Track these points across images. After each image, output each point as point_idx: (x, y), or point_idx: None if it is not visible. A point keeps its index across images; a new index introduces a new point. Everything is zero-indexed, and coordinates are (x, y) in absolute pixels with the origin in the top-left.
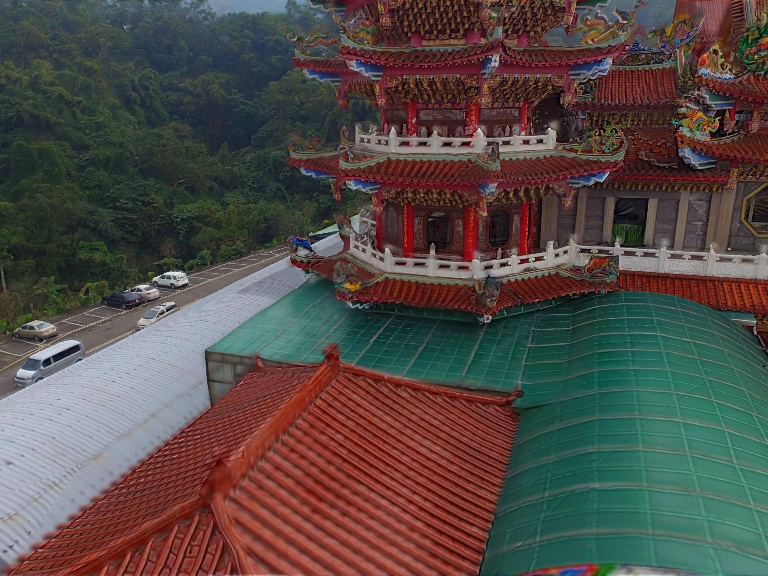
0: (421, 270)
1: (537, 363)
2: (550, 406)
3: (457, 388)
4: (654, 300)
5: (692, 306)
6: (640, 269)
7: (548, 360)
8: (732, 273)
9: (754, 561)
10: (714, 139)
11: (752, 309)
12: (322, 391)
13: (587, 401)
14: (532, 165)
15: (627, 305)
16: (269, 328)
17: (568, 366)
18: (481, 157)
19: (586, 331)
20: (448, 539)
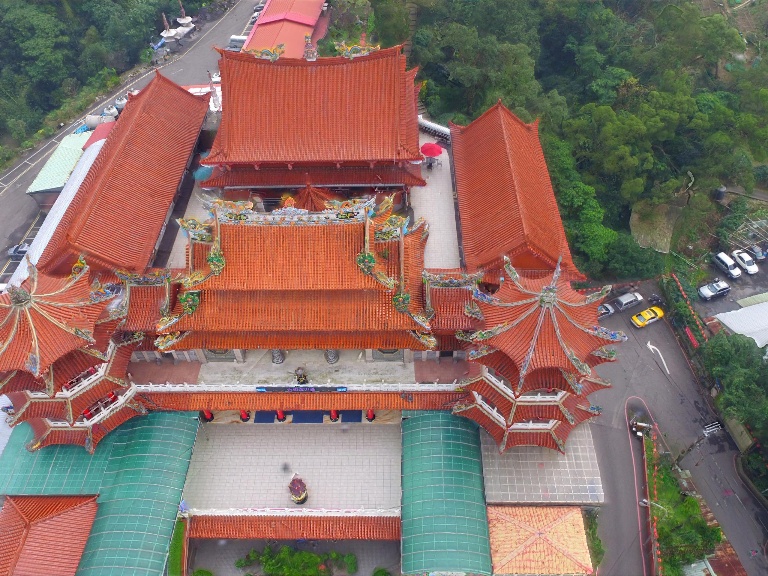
0: (65, 425)
1: (108, 473)
2: (104, 503)
3: (80, 495)
4: (158, 422)
5: (172, 420)
6: (163, 390)
7: (112, 471)
8: (196, 389)
9: (120, 568)
10: (180, 337)
11: (198, 410)
12: (26, 538)
13: (111, 505)
14: (93, 393)
15: (147, 428)
16: (8, 470)
17: (116, 477)
18: (68, 405)
19: (128, 450)
20: (68, 568)
